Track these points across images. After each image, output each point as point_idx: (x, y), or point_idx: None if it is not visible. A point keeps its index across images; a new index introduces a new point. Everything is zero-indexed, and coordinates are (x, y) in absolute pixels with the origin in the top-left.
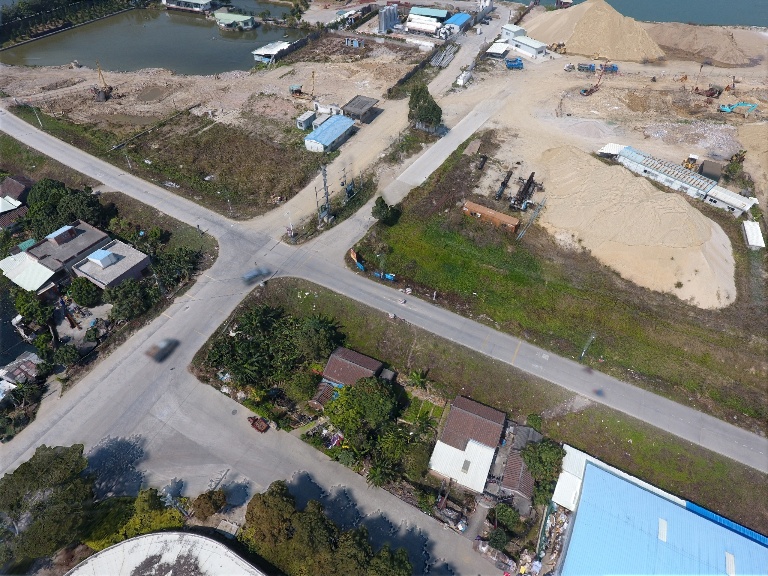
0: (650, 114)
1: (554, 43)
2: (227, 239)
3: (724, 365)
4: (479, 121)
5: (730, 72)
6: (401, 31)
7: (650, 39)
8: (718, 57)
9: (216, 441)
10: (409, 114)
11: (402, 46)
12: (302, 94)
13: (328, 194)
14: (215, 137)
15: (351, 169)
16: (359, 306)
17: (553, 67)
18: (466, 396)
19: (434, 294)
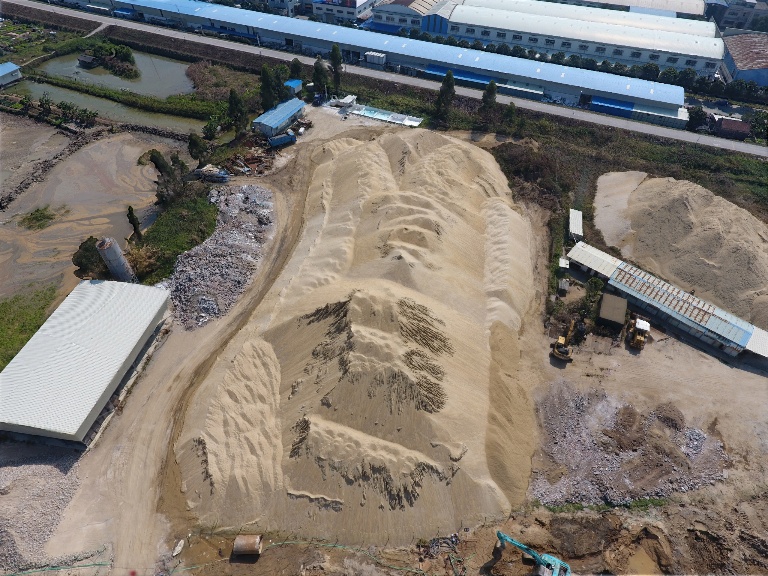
0: None
1: None
2: None
3: None
4: None
5: None
6: None
7: None
8: None
9: None
10: None
11: None
12: None
13: None
14: None
15: None
16: None
17: None
18: None
19: None
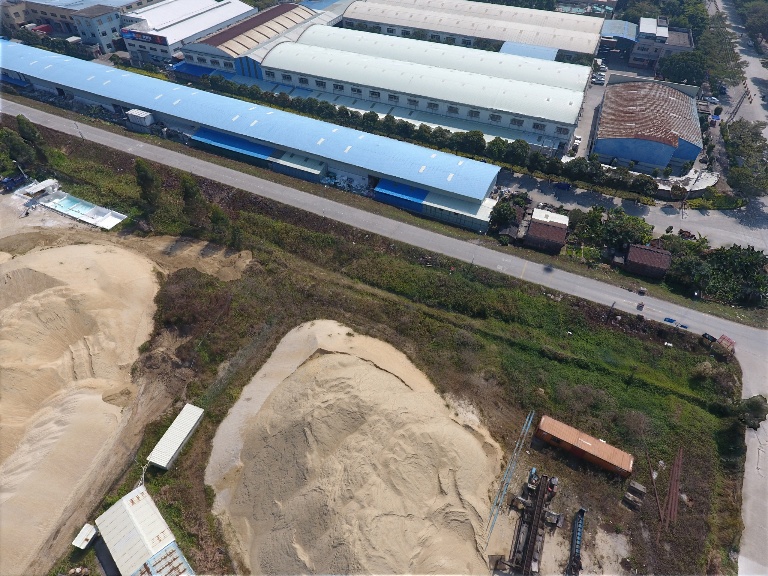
0: None
1: None
2: None
3: None
4: None
5: None
6: None
7: None
8: None
9: (704, 229)
10: None
11: None
12: None
13: None
14: None
15: None
16: None
17: None
18: (554, 255)
19: None
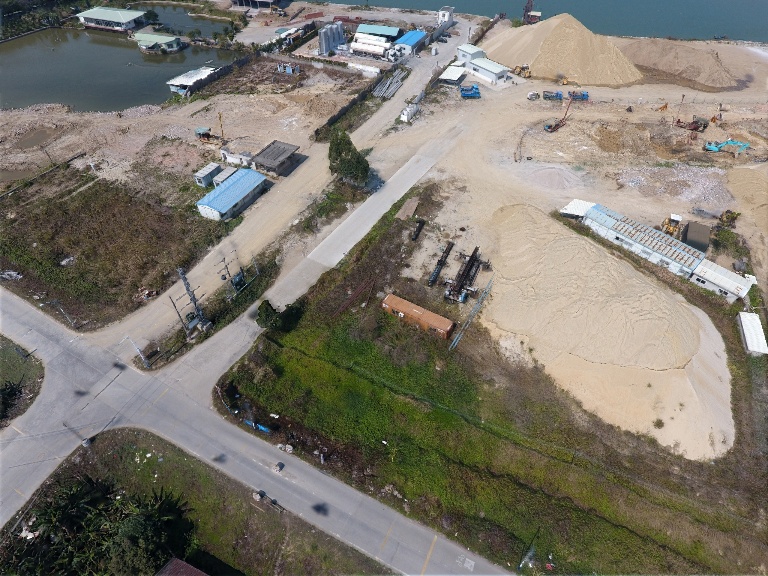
0: (624, 156)
1: (517, 65)
2: (58, 364)
3: (722, 560)
4: (421, 169)
5: (716, 97)
6: (345, 53)
7: (625, 60)
8: (702, 79)
9: None
10: (329, 168)
11: (343, 72)
12: (211, 138)
13: (195, 299)
14: (90, 200)
15: (252, 243)
16: (216, 478)
17: (515, 95)
18: None
19: (321, 458)
